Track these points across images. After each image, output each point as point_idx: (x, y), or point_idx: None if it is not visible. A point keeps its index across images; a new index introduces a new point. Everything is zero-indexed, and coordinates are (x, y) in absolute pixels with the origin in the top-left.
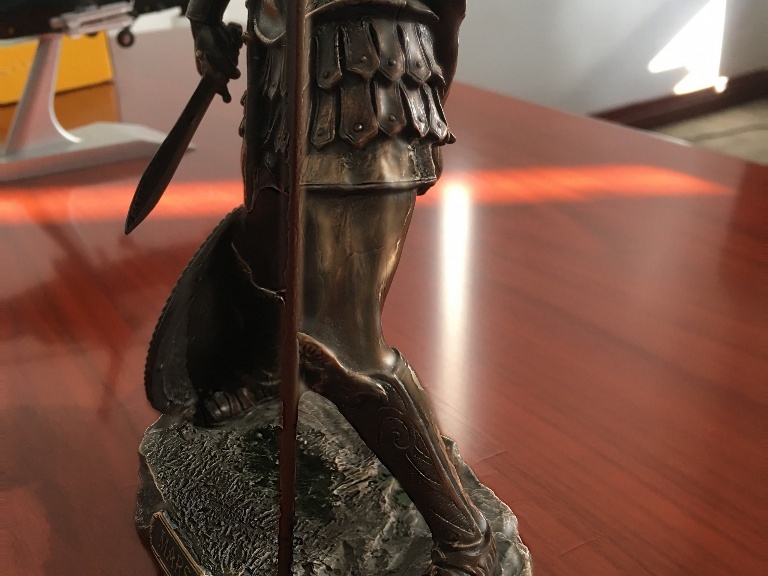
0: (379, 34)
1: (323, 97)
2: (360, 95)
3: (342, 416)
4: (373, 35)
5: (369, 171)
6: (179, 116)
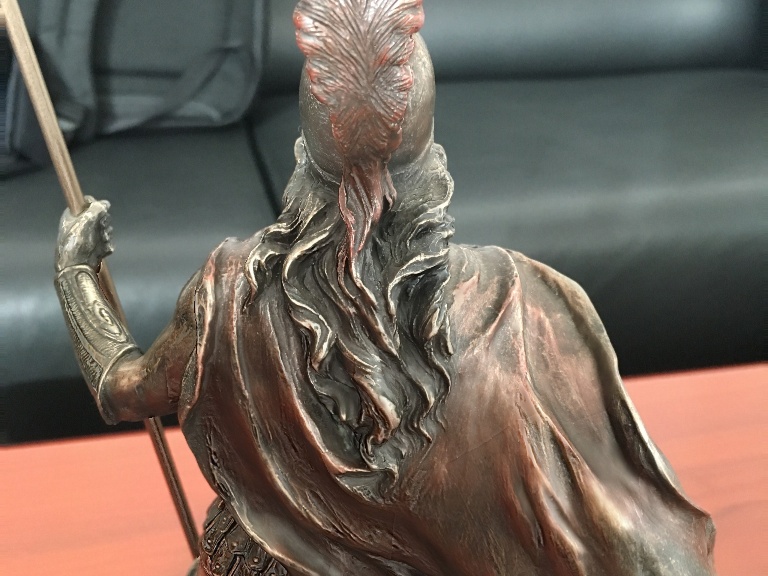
0: None
1: None
2: None
3: None
4: None
5: None
6: None
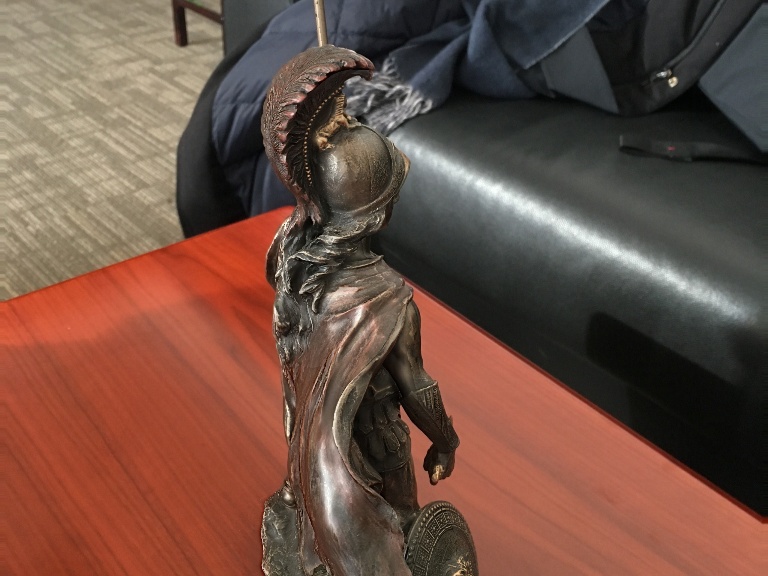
0: None
1: None
2: None
3: None
4: None
5: None
6: None
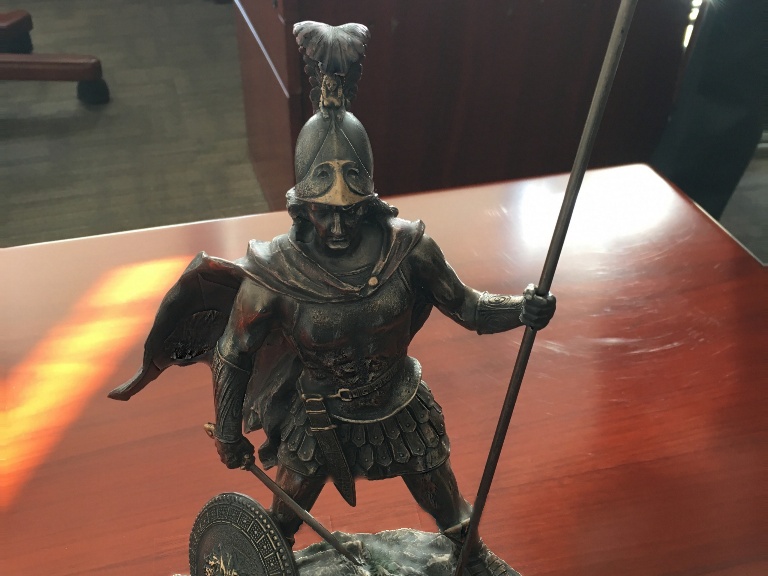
0: (422, 383)
1: (421, 426)
2: (434, 413)
3: (304, 573)
4: (422, 385)
5: (447, 439)
6: (287, 496)
